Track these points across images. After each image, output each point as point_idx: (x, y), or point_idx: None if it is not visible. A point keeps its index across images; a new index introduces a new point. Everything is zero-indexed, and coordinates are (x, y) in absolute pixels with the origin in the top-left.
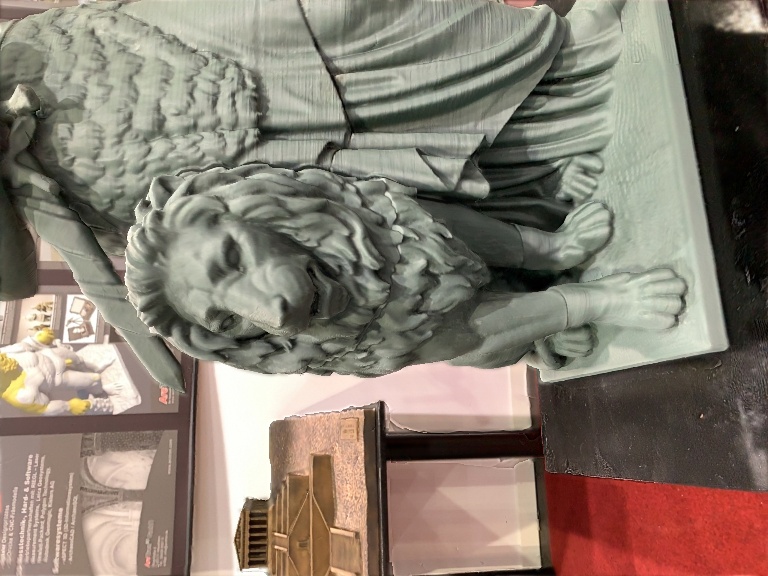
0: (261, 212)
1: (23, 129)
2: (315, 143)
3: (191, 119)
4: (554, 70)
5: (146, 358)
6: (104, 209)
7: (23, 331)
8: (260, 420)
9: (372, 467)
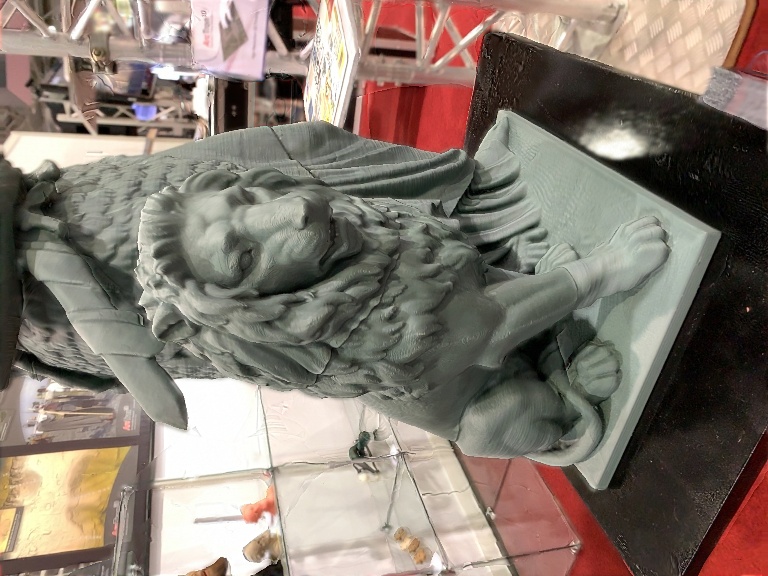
0: (269, 176)
1: (41, 189)
2: None
3: None
4: (477, 183)
5: (142, 386)
6: (106, 257)
7: None
8: None
9: None
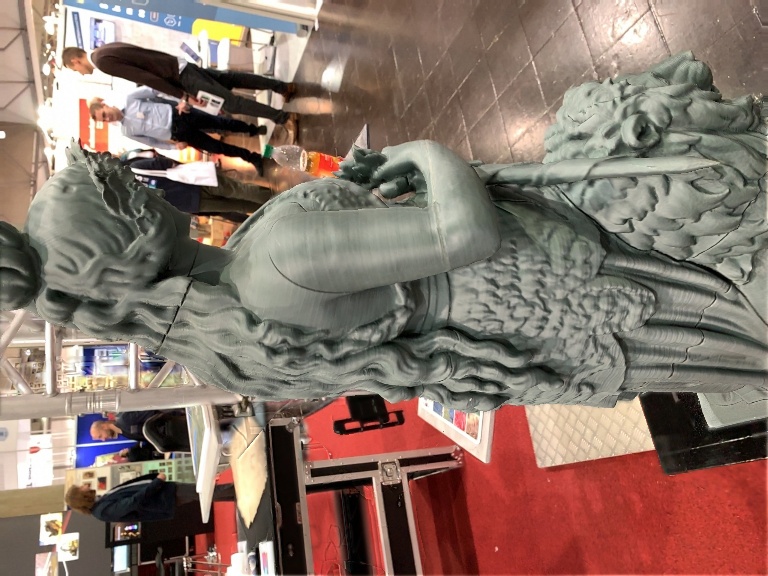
0: None
1: None
2: None
3: None
4: None
5: None
6: (519, 186)
7: None
8: None
9: None
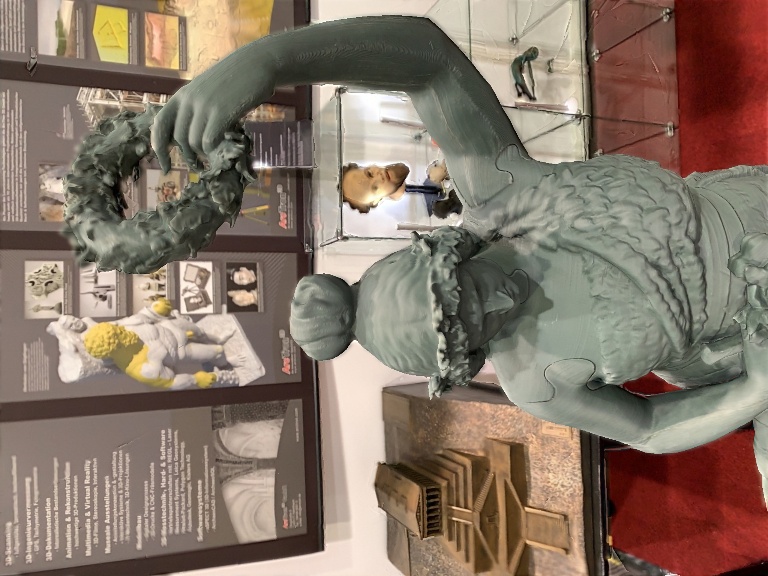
0: None
1: None
2: None
3: None
4: None
5: None
6: None
7: (138, 301)
8: (368, 384)
9: (587, 463)
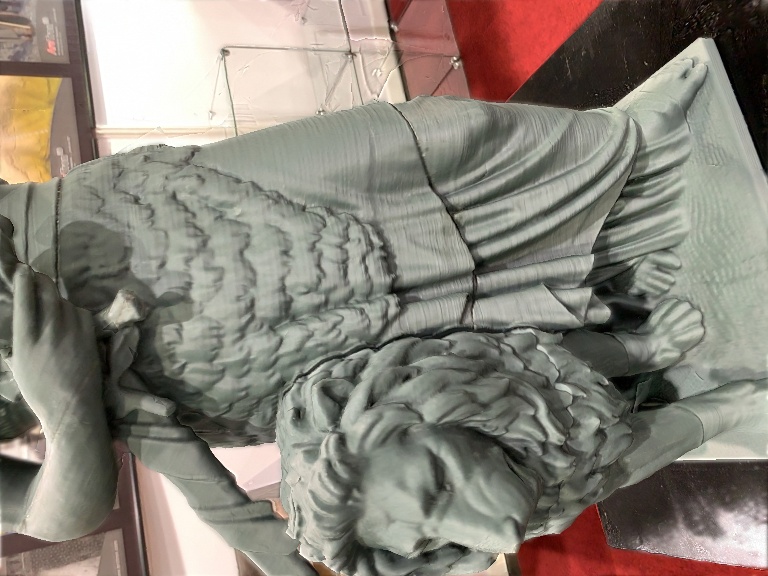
0: (458, 414)
1: (126, 345)
2: (456, 300)
3: (322, 295)
4: None
5: None
6: (219, 414)
7: None
8: None
9: None
